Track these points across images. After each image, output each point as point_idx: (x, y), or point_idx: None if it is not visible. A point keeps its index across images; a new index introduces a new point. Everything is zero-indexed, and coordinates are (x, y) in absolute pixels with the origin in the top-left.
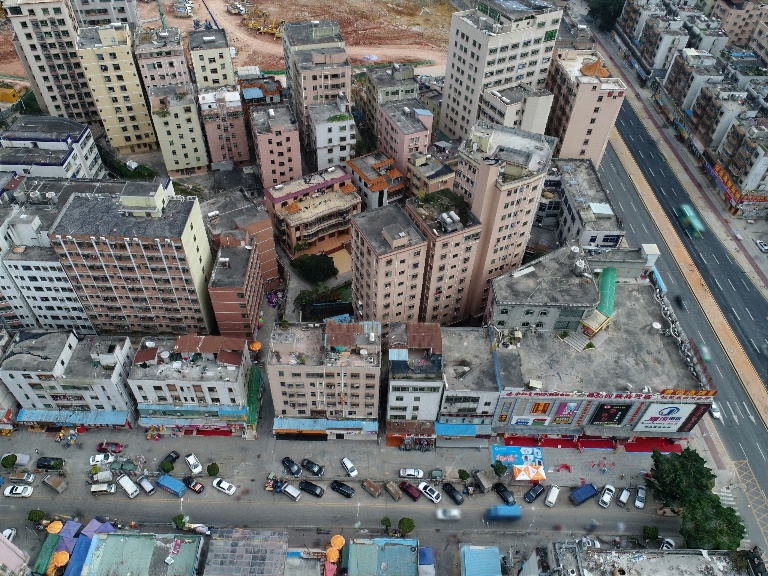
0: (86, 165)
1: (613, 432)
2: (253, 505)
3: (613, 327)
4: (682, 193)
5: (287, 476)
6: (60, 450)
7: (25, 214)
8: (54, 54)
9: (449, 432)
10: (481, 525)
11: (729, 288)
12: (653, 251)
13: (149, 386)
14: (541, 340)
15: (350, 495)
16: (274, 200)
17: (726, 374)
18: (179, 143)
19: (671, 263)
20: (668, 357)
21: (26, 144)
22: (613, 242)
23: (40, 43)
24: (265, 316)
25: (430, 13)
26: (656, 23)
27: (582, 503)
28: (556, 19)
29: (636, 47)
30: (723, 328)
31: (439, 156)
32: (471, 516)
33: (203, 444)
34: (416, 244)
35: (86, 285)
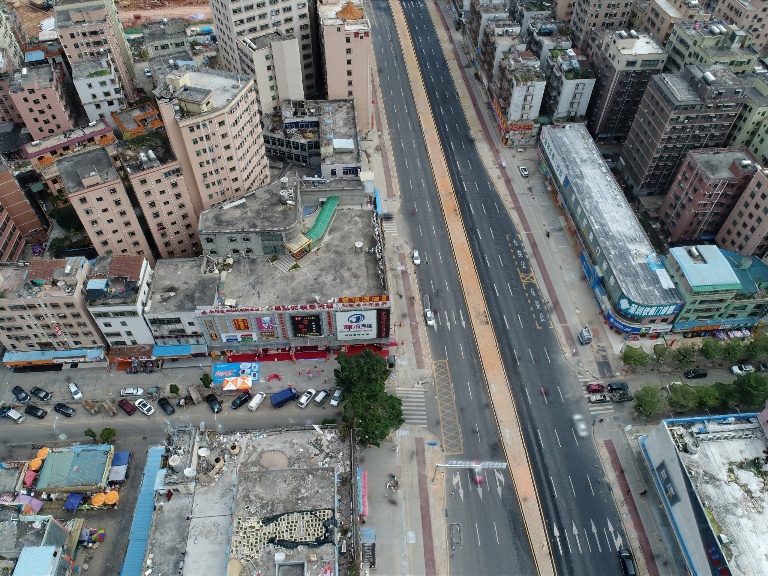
0: None
1: (316, 342)
2: None
3: (324, 249)
4: (464, 128)
5: (16, 403)
6: None
7: None
8: None
9: (166, 353)
10: None
11: (480, 211)
12: (368, 178)
13: None
14: (252, 265)
15: (69, 414)
16: (28, 155)
17: (452, 287)
18: None
19: (433, 193)
20: (365, 272)
21: None
22: (354, 174)
23: None
24: None
25: None
26: None
27: (283, 406)
28: None
29: None
30: (462, 247)
31: None
32: (179, 424)
33: None
34: (107, 182)
35: None
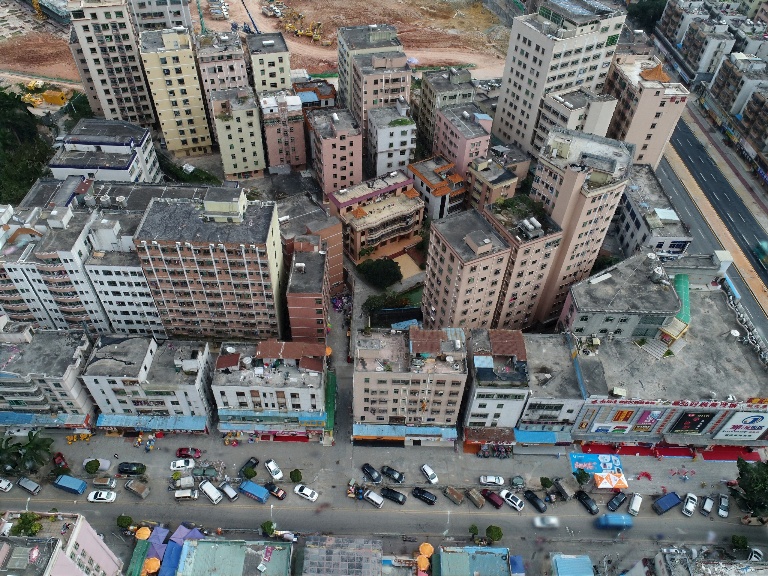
0: (146, 169)
1: (694, 440)
2: (336, 512)
3: (689, 334)
4: (735, 198)
5: (368, 483)
6: (139, 455)
7: (104, 219)
8: (113, 57)
9: (529, 439)
10: (566, 533)
11: None
12: (726, 258)
13: (232, 392)
14: (619, 347)
15: (433, 502)
16: (340, 205)
17: None
18: (239, 147)
19: (731, 269)
20: (748, 365)
21: (90, 148)
22: (679, 248)
23: (100, 46)
24: (332, 321)
25: (464, 16)
26: (701, 27)
27: (665, 512)
28: (619, 24)
29: (678, 51)
30: None
31: (500, 161)
32: (555, 524)
33: (281, 450)
34: (500, 251)
35: (164, 290)
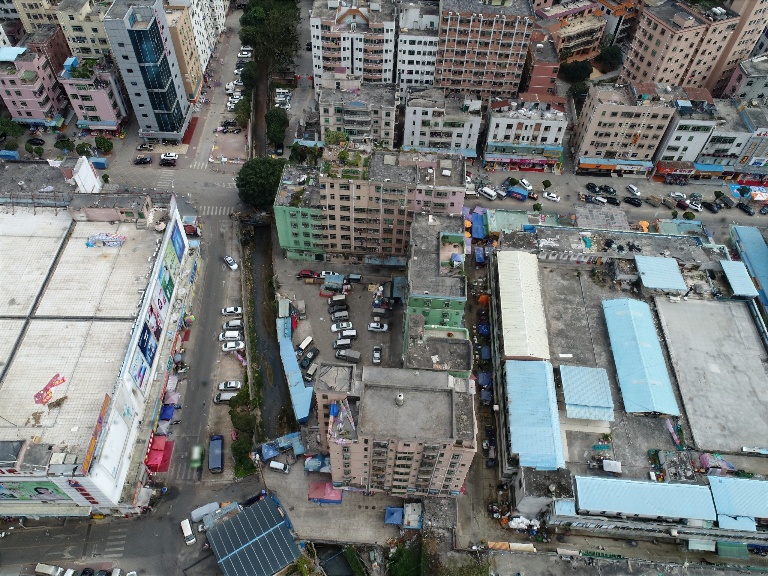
0: None
1: None
2: None
3: None
4: None
5: (592, 194)
6: None
7: None
8: None
9: (705, 169)
10: None
11: None
12: None
13: (504, 124)
14: None
15: (640, 204)
16: (548, 17)
17: None
18: None
19: None
20: None
21: None
22: None
23: None
24: None
25: None
26: None
27: None
28: None
29: None
30: None
31: None
32: (725, 220)
33: (526, 175)
34: (700, 25)
35: (446, 59)
